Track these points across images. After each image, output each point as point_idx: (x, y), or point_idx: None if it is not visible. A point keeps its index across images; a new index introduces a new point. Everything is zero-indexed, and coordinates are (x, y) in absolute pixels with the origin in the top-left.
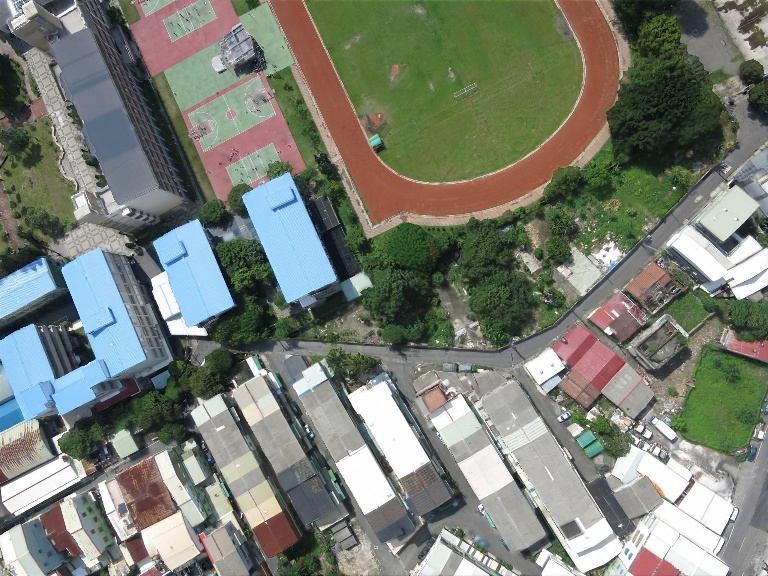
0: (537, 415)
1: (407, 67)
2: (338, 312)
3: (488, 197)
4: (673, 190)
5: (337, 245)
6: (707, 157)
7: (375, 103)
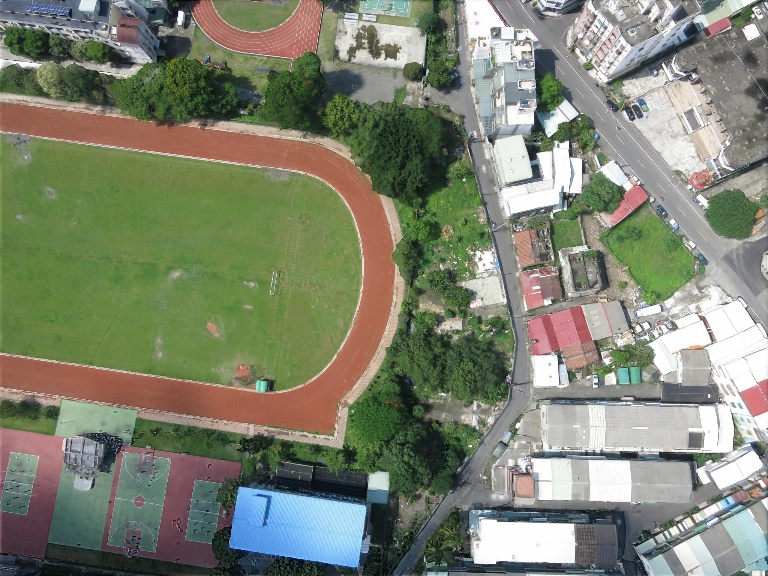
0: (586, 406)
1: (217, 316)
2: (389, 519)
3: (375, 323)
4: (465, 182)
5: (330, 481)
6: (456, 142)
7: (227, 364)
